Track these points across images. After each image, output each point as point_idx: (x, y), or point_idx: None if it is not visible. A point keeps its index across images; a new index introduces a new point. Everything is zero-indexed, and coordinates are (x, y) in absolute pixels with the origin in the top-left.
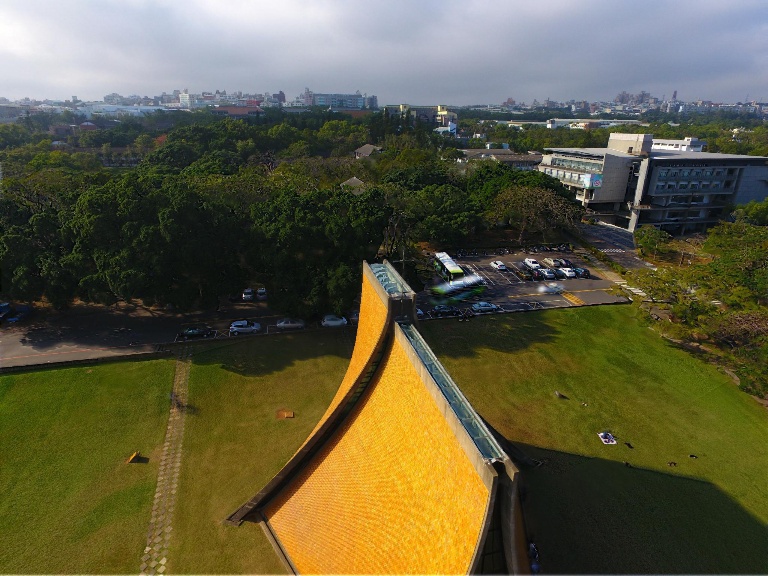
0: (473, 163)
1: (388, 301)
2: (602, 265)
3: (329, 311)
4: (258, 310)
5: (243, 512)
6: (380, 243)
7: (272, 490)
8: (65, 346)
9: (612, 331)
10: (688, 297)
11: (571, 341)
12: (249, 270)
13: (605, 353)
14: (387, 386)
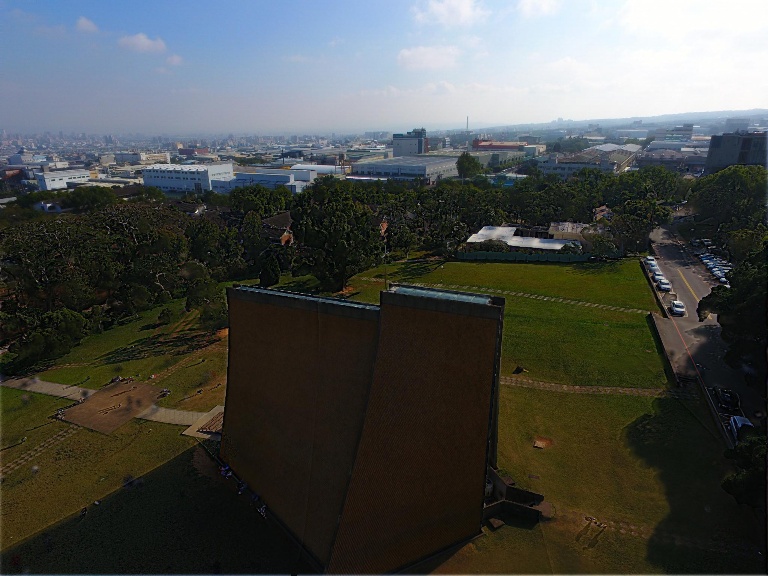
0: None
1: None
2: None
3: None
4: None
5: None
6: None
7: None
8: (697, 339)
9: None
10: None
11: None
12: None
13: None
14: None
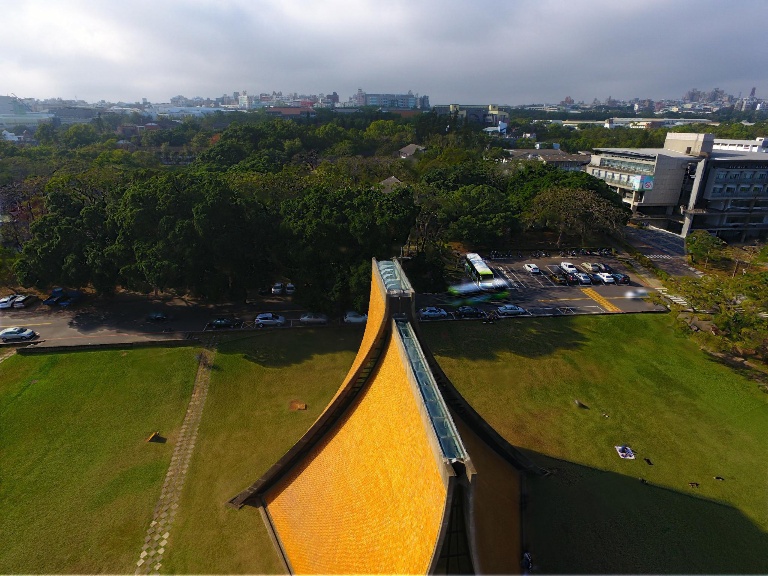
0: (516, 163)
1: (386, 298)
2: (645, 271)
3: (350, 307)
4: (285, 304)
5: (244, 496)
6: None
7: (272, 477)
8: (106, 330)
9: (646, 341)
10: (732, 308)
11: (600, 349)
12: (281, 265)
13: (635, 363)
14: (382, 382)
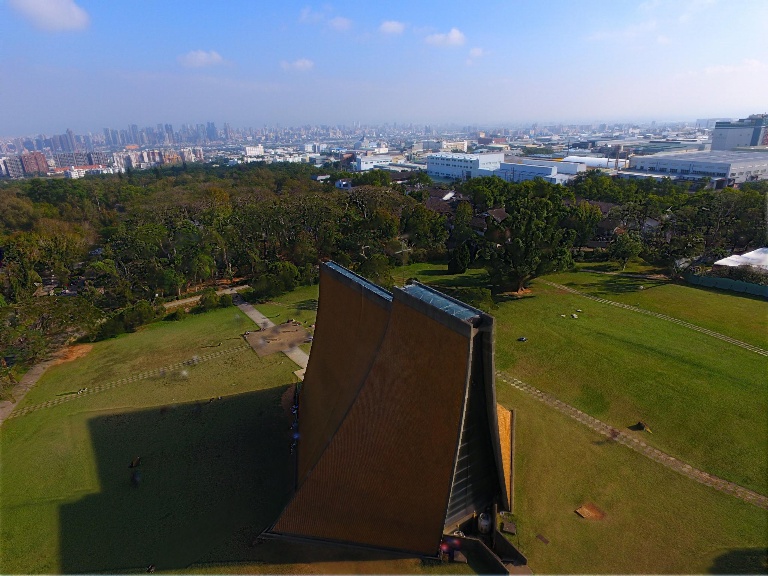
0: None
1: None
2: None
3: None
4: None
5: None
6: None
7: None
8: None
9: None
10: None
11: None
12: None
13: None
14: None
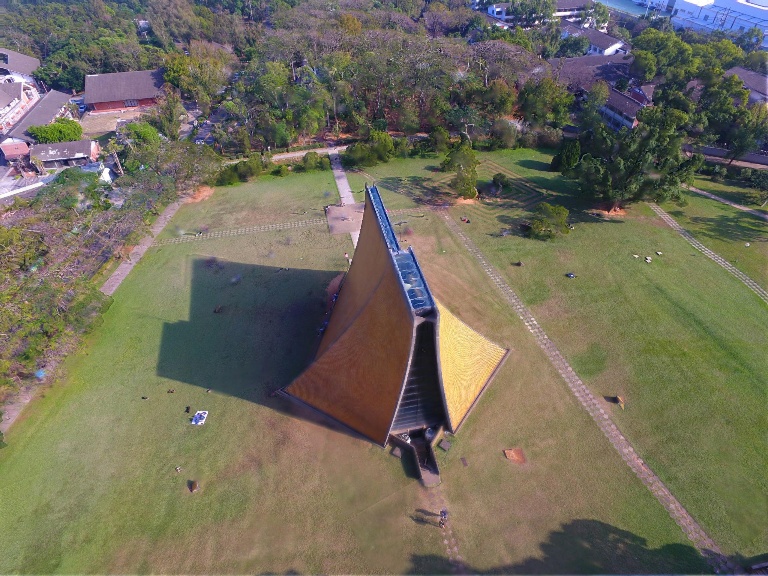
0: None
1: None
2: None
3: None
4: None
5: None
6: None
7: None
8: None
9: None
10: None
11: None
12: None
13: None
14: None
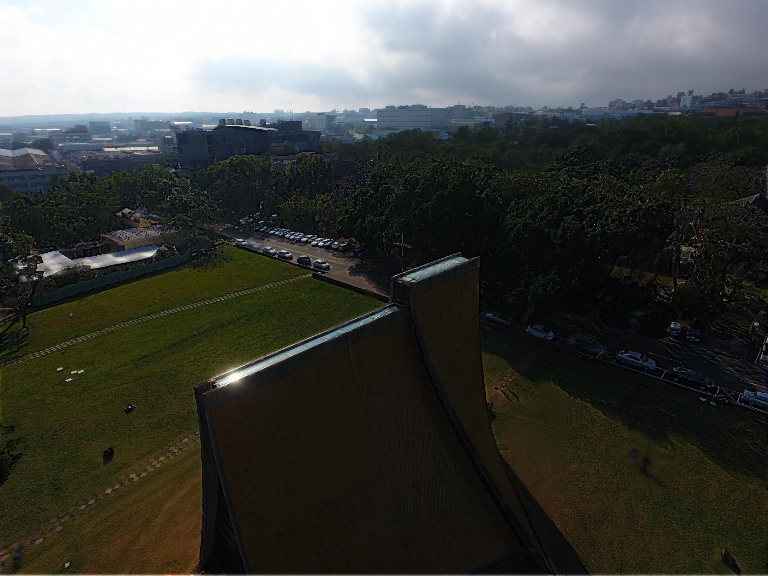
0: None
1: None
2: None
3: None
4: None
5: None
6: (612, 262)
7: None
8: (362, 277)
9: None
10: None
11: None
12: None
13: None
14: None
